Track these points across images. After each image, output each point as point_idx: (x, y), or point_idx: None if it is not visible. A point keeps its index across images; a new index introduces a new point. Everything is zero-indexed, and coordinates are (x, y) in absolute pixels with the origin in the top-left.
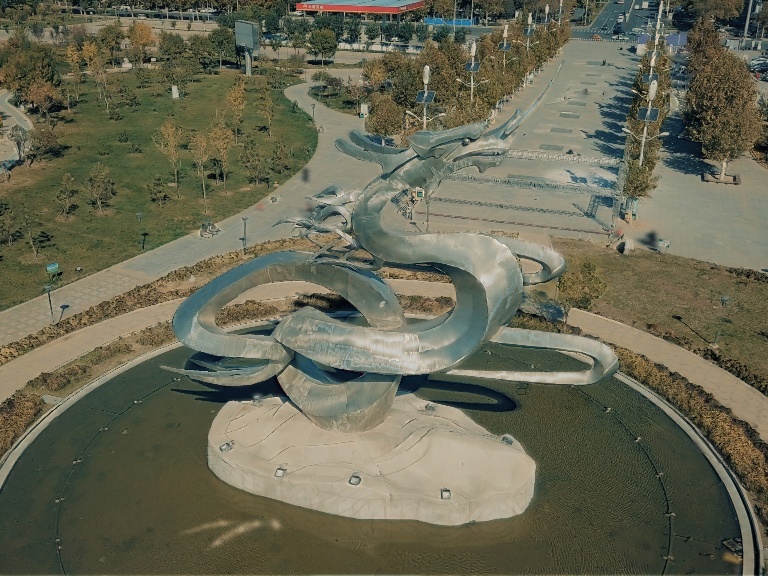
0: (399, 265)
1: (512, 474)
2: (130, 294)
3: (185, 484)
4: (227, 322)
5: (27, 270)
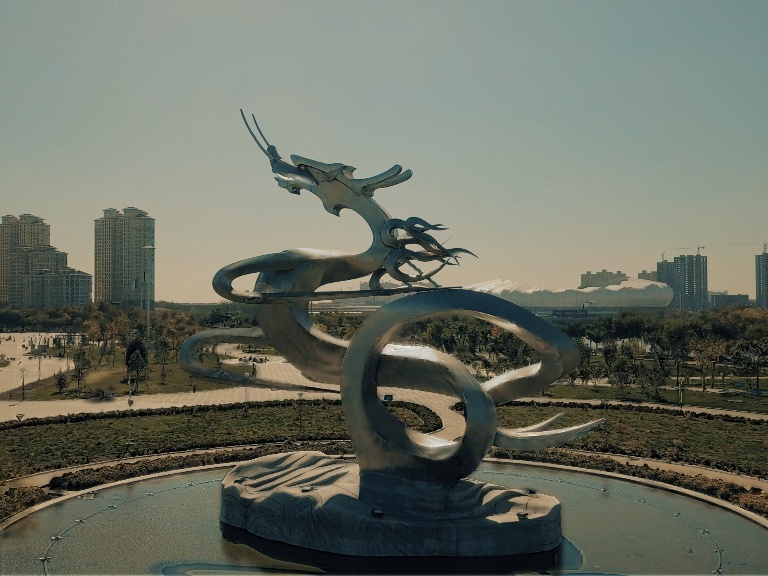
0: (354, 293)
1: None
2: None
3: (569, 523)
4: None
5: None
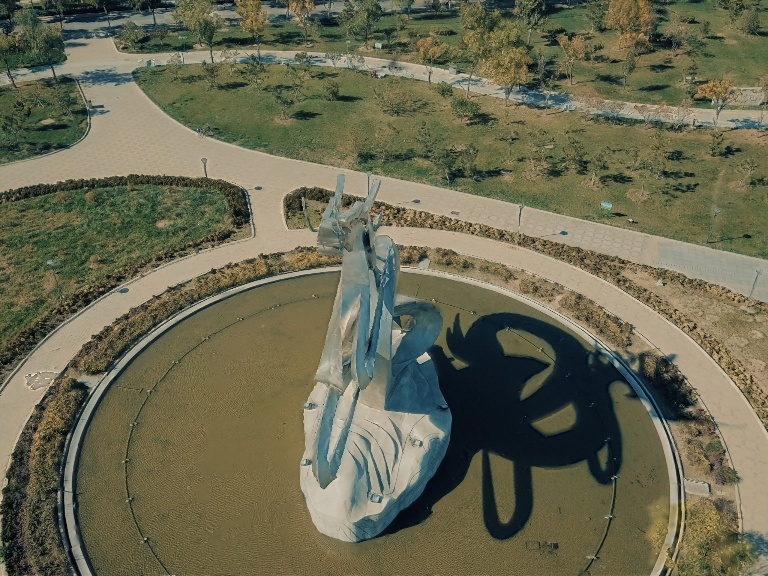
0: None
1: (325, 499)
2: (601, 257)
3: None
4: (582, 320)
5: (615, 199)
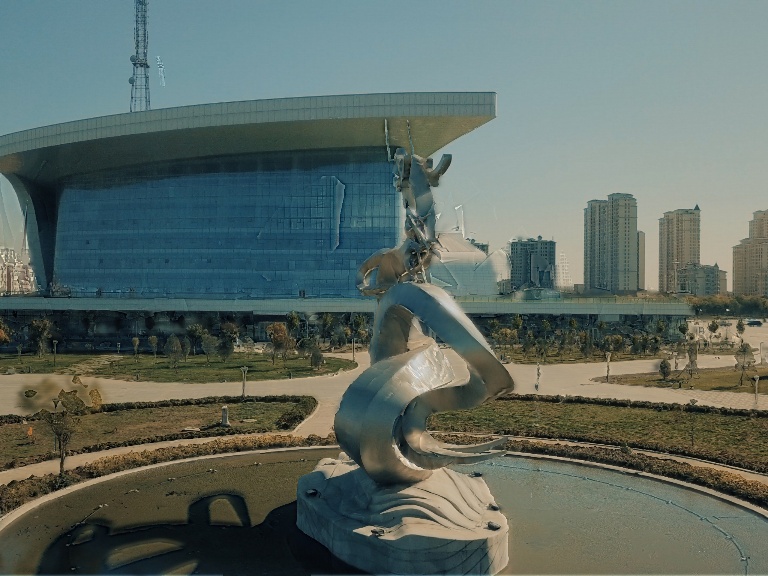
0: None
1: None
2: None
3: None
4: None
5: None
